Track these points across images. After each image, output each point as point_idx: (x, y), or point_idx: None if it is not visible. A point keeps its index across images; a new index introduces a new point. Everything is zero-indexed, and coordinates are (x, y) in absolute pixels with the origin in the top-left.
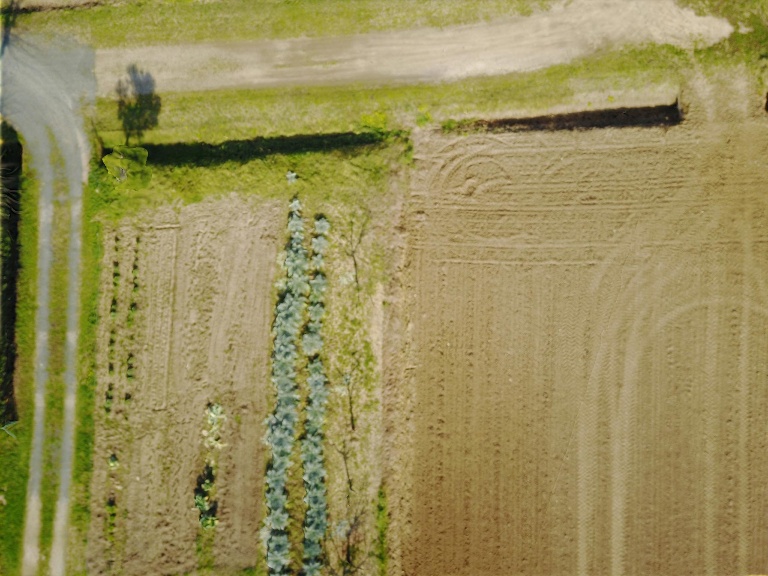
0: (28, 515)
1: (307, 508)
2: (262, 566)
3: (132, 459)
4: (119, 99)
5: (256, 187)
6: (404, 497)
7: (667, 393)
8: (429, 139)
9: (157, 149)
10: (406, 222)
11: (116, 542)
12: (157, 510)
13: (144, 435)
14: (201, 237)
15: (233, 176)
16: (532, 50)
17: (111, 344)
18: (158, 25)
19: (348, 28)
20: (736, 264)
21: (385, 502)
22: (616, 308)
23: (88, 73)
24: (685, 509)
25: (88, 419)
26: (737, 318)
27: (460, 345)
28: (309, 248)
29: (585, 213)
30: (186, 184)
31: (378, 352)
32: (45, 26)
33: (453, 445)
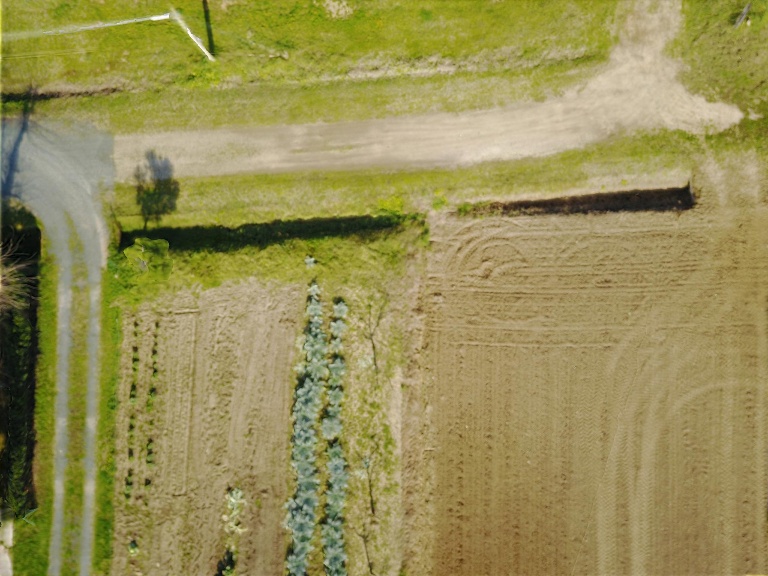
0: None
1: None
2: None
3: (152, 545)
4: (138, 184)
5: (275, 272)
6: None
7: (684, 476)
8: (445, 221)
9: (175, 232)
10: (423, 304)
11: None
12: None
13: (164, 521)
14: (220, 321)
15: (252, 261)
16: (546, 135)
17: (131, 430)
18: (176, 111)
19: (365, 113)
20: (750, 346)
21: None
22: (632, 391)
23: (107, 159)
24: None
25: (108, 505)
26: (751, 400)
27: (478, 427)
28: (328, 332)
29: (600, 296)
30: (205, 269)
31: (397, 435)
32: (64, 112)
33: (472, 528)
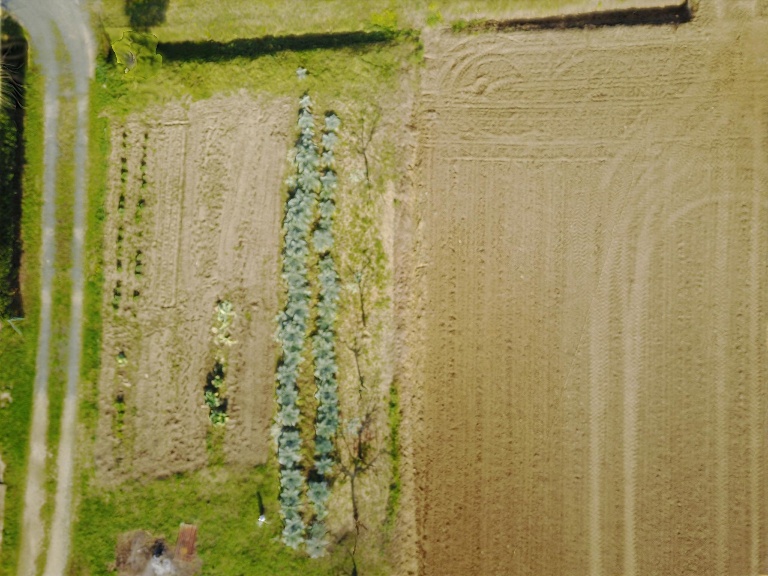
0: (35, 413)
1: (318, 405)
2: (273, 463)
3: (141, 356)
4: None
5: (266, 83)
6: (415, 395)
7: (678, 286)
8: (440, 38)
9: (165, 47)
10: (417, 121)
11: (124, 440)
12: (166, 408)
13: (153, 332)
14: (210, 134)
15: (243, 71)
16: None
17: (119, 241)
18: None
19: None
20: (746, 159)
21: (397, 399)
22: (627, 203)
23: None
24: (696, 402)
25: (96, 316)
26: (747, 213)
27: (472, 242)
28: (320, 145)
29: (596, 110)
30: (195, 80)
31: (389, 249)
32: None
33: (465, 342)
